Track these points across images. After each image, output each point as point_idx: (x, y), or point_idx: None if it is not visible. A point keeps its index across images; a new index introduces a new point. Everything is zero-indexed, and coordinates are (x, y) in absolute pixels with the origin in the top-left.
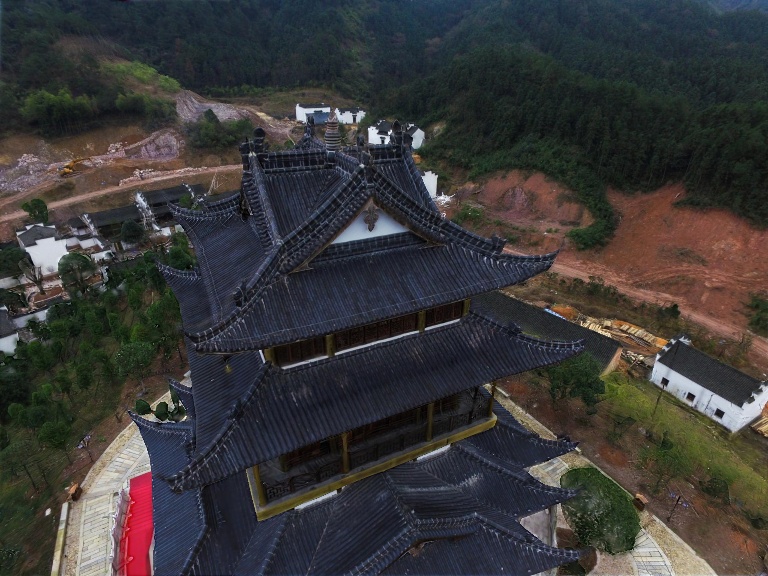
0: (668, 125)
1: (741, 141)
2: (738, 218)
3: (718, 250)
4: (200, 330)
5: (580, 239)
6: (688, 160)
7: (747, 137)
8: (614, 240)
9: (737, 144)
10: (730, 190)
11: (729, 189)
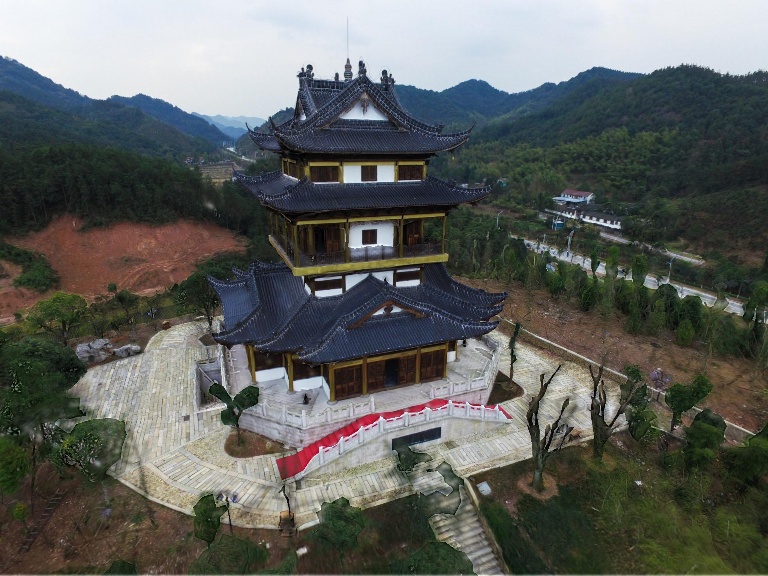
0: (7, 169)
1: (98, 170)
2: (138, 224)
3: (143, 250)
4: (362, 201)
5: (36, 282)
6: (62, 193)
7: (97, 167)
8: (61, 274)
9: (97, 172)
10: (118, 206)
11: (116, 206)
